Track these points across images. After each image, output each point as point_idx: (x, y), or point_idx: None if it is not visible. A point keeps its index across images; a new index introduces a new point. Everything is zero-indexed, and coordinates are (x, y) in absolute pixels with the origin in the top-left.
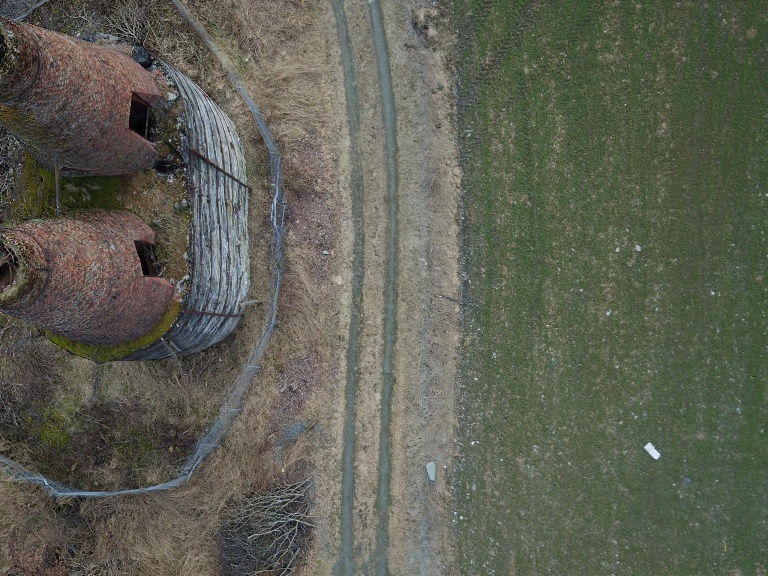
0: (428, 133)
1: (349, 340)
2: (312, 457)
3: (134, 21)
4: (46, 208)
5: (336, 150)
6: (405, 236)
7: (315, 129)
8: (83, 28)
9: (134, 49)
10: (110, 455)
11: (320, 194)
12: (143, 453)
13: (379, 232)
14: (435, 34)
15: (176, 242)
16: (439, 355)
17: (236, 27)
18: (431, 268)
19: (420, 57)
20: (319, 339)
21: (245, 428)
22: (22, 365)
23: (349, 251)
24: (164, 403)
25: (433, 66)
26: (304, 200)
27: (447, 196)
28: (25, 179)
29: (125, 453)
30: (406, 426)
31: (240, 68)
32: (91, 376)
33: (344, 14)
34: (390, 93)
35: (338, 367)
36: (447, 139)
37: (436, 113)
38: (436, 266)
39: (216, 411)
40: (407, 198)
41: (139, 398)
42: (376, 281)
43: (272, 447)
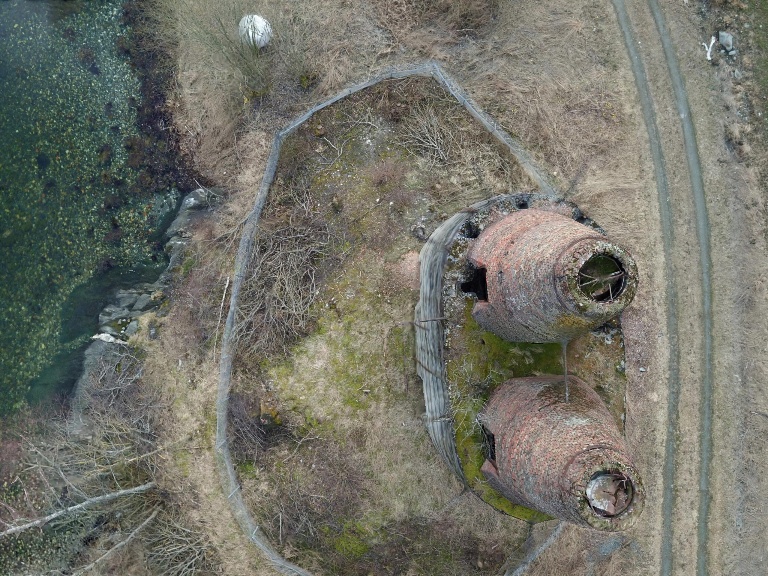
0: (741, 249)
1: (665, 457)
2: (628, 574)
3: (435, 132)
4: (490, 372)
5: (651, 266)
6: (720, 352)
7: (630, 245)
8: (372, 134)
9: (574, 211)
10: (407, 565)
11: (637, 311)
12: (441, 564)
13: (694, 349)
14: (749, 150)
15: (616, 405)
16: (755, 472)
17: (542, 140)
18: (745, 384)
19: (733, 172)
20: (635, 456)
21: (558, 544)
22: (326, 478)
23: (664, 368)
24: (474, 518)
25: (747, 182)
26: (622, 318)
27: (762, 312)
28: (465, 341)
29: (423, 564)
30: (723, 544)
31: (548, 182)
32: (400, 491)
33: (656, 129)
34: (704, 209)
35: (655, 484)
36: (762, 255)
37: (750, 229)
38: (751, 383)
39: (529, 527)
40: (722, 314)
41: (449, 513)
42: (692, 398)
43: (584, 563)
